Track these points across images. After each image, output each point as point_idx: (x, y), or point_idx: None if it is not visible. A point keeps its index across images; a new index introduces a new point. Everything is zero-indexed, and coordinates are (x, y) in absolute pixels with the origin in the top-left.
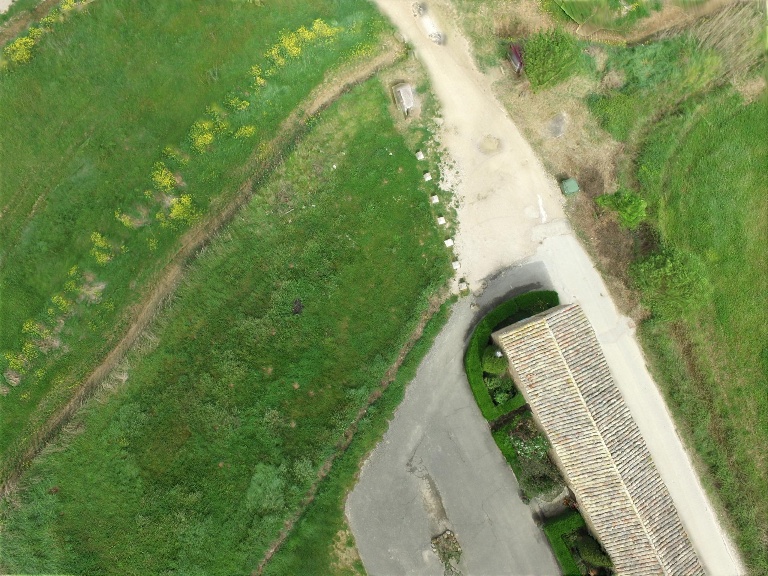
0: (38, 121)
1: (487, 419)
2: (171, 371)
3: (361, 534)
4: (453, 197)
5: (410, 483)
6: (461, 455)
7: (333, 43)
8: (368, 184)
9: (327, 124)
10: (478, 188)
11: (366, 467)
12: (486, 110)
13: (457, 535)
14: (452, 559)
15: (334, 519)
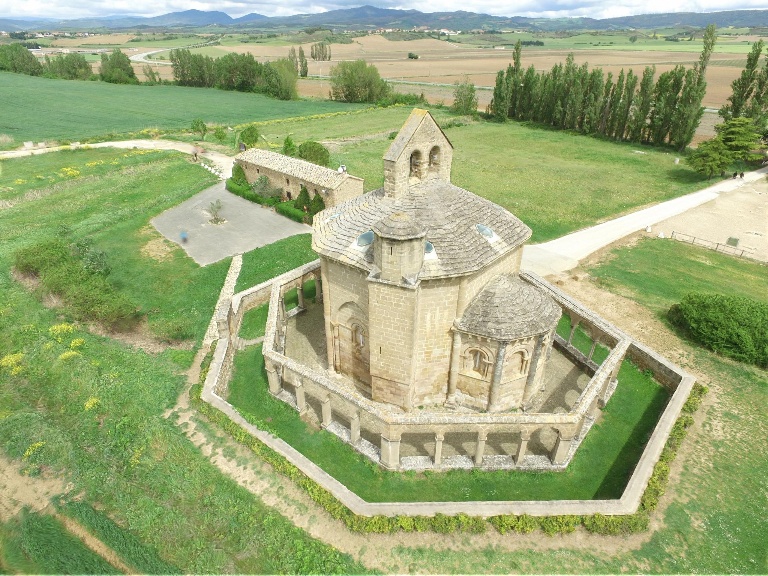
0: (1, 170)
1: (240, 196)
2: (45, 203)
3: (159, 225)
4: (219, 169)
5: (194, 211)
6: (225, 203)
7: (163, 153)
8: (176, 170)
9: (157, 163)
10: (231, 167)
11: (166, 211)
12: (233, 158)
13: (224, 218)
14: (221, 224)
15: (141, 223)
